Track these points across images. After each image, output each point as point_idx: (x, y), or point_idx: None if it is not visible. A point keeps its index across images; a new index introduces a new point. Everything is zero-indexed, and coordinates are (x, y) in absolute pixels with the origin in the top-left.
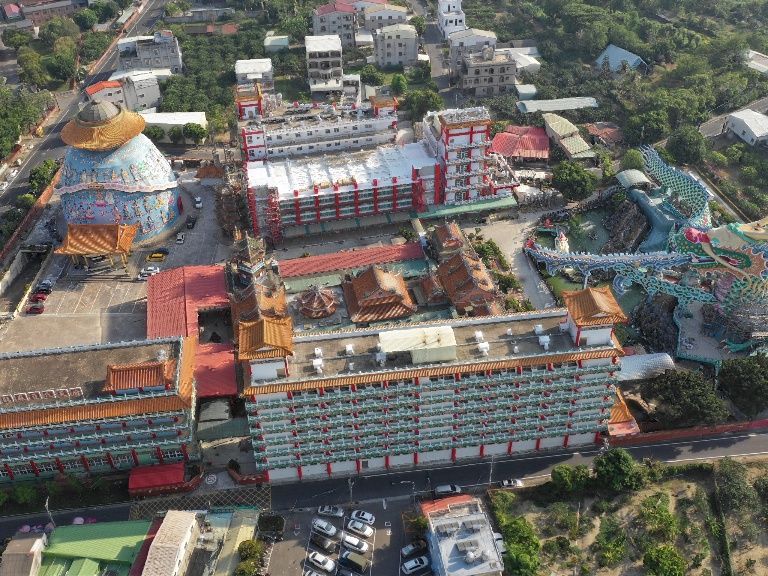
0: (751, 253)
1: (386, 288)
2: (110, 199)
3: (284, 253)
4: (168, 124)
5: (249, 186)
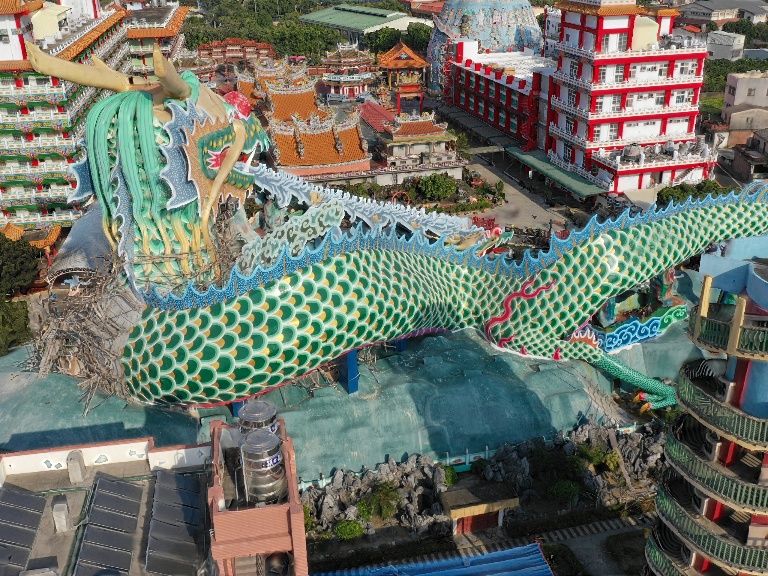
0: None
1: (272, 98)
2: None
3: None
4: None
5: None
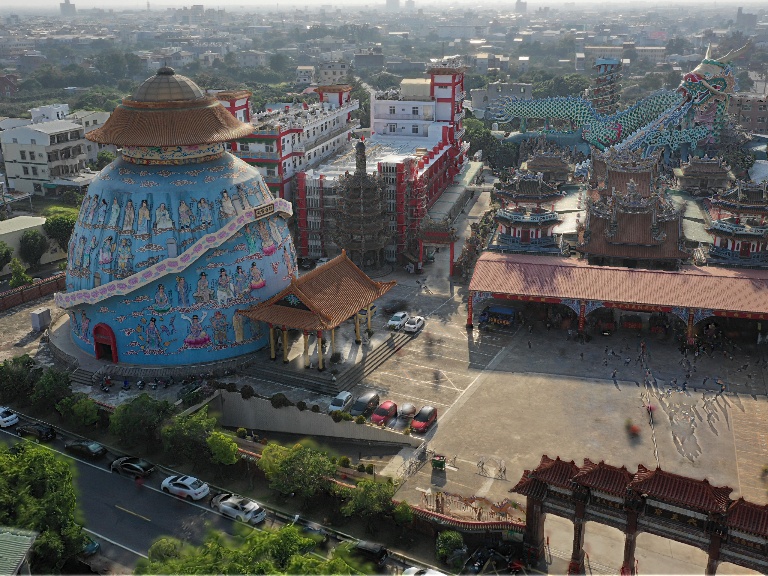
0: (725, 75)
1: None
2: (277, 235)
3: (442, 253)
4: (9, 233)
5: (398, 162)
